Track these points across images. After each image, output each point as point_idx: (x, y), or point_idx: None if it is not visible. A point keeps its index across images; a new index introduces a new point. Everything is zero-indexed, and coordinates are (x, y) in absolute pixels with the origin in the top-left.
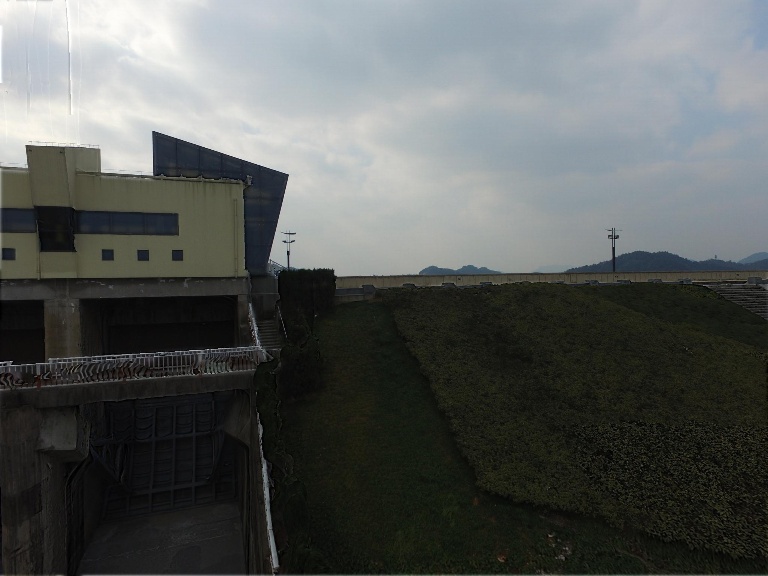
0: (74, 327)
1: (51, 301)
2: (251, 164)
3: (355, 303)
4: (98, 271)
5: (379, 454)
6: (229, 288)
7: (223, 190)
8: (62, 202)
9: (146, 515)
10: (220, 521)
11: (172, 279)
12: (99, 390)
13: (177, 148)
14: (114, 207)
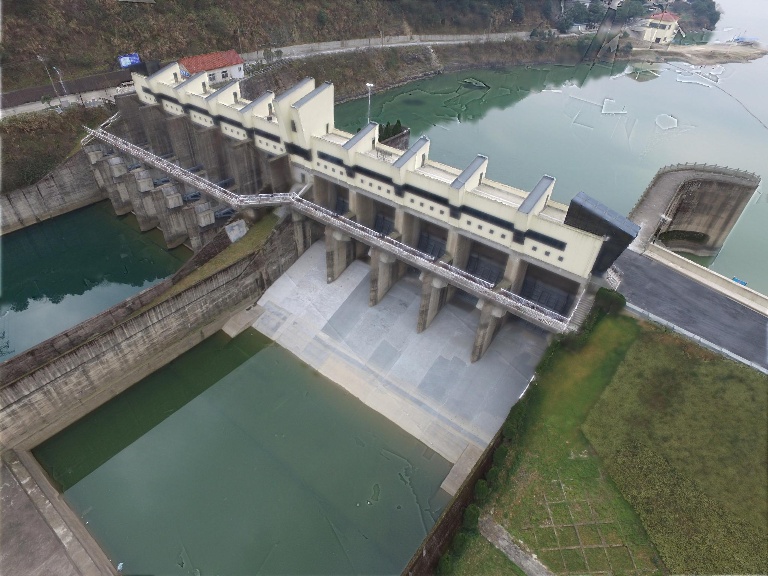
0: (516, 267)
1: (511, 256)
2: (616, 226)
3: (630, 320)
4: (529, 253)
5: (571, 392)
6: (578, 279)
7: (591, 240)
8: (523, 230)
9: (523, 328)
10: (544, 351)
11: (555, 266)
12: (510, 309)
13: (581, 210)
14: (542, 232)
